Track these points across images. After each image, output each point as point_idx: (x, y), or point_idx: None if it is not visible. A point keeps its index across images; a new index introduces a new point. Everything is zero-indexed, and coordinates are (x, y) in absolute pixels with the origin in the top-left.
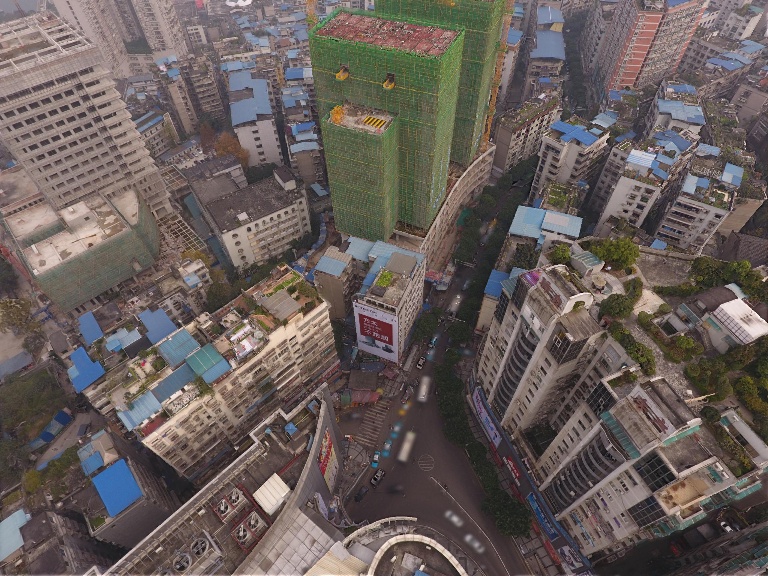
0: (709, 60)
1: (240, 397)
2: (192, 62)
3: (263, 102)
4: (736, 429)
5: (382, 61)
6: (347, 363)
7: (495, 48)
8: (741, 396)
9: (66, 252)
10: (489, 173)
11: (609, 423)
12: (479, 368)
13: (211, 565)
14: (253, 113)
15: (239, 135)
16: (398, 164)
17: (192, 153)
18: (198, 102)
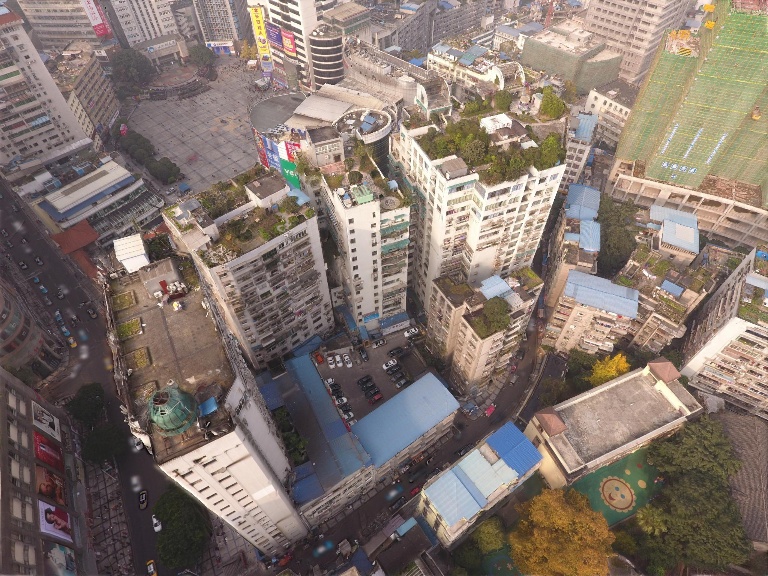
0: None
1: None
2: None
3: None
4: None
5: (723, 3)
6: None
7: None
8: None
9: (551, 43)
10: None
11: None
12: None
13: None
14: None
15: None
16: None
17: None
18: None
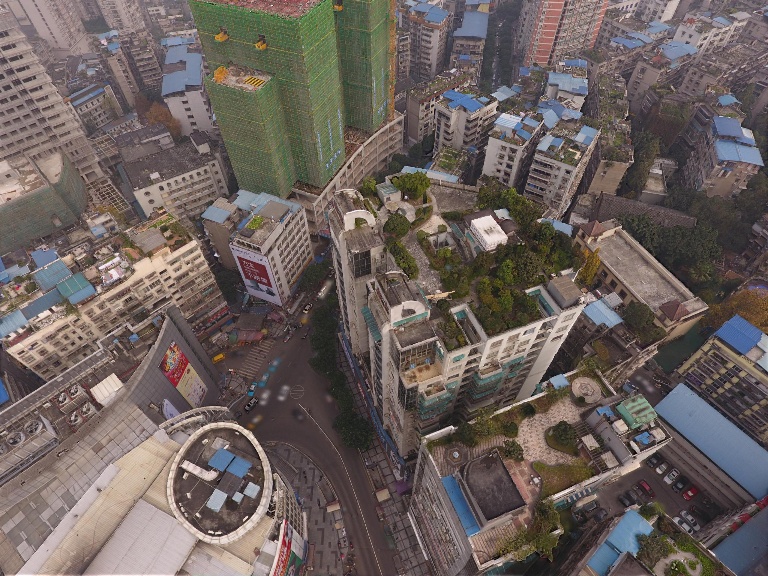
0: (613, 39)
1: (112, 323)
2: (133, 37)
3: (194, 74)
4: (470, 320)
5: (252, 23)
6: (239, 307)
7: (386, 19)
8: (479, 294)
9: None
10: (402, 143)
11: (366, 315)
12: None
13: (46, 444)
14: (182, 84)
15: (169, 105)
16: (285, 123)
17: (133, 125)
18: (141, 76)
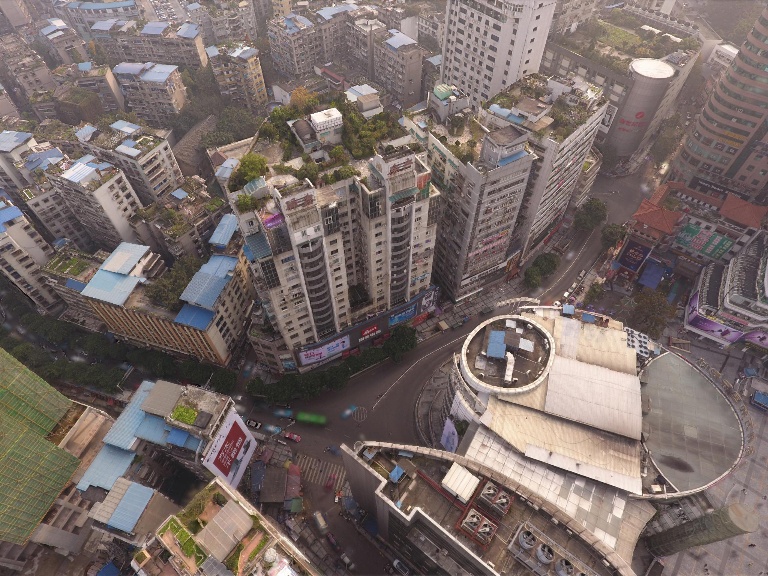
0: None
1: None
2: None
3: None
4: None
5: None
6: None
7: None
8: None
9: None
10: None
11: (397, 198)
12: (288, 342)
13: None
14: None
15: None
16: None
17: None
18: None
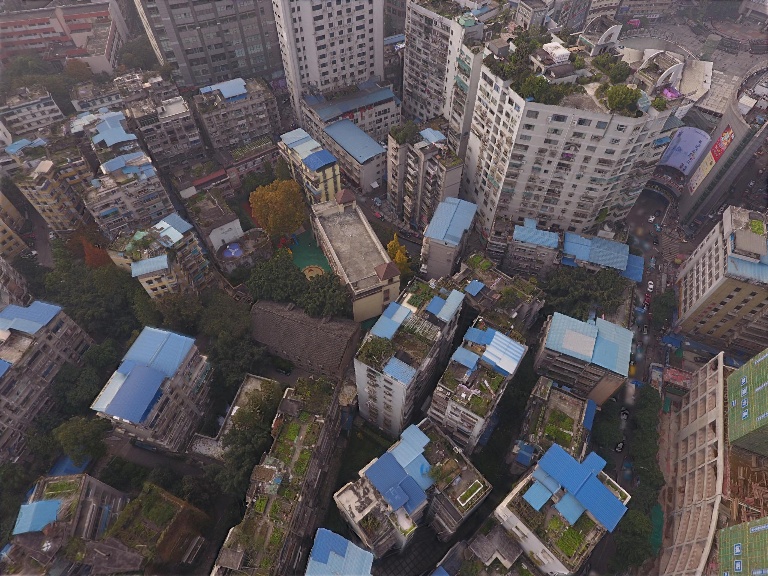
0: None
1: None
2: None
3: None
4: None
5: None
6: None
7: None
8: None
9: None
10: None
11: None
12: None
13: None
14: None
15: None
16: None
17: None
18: None
